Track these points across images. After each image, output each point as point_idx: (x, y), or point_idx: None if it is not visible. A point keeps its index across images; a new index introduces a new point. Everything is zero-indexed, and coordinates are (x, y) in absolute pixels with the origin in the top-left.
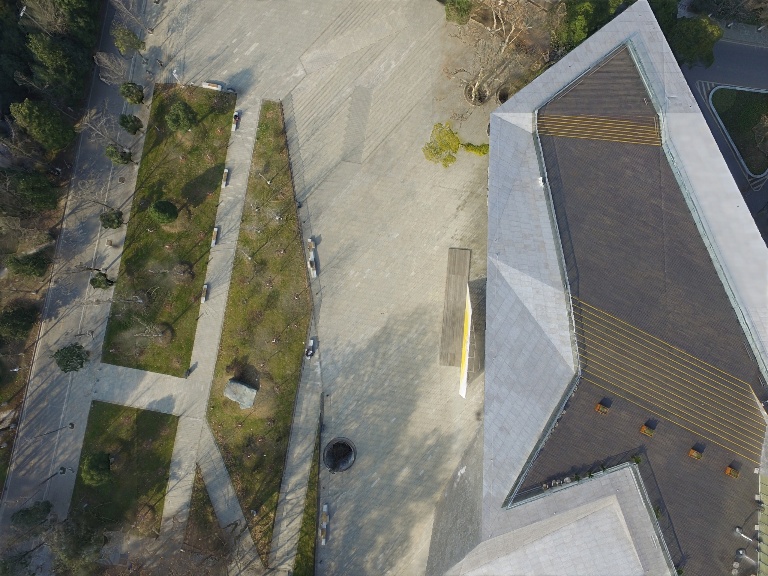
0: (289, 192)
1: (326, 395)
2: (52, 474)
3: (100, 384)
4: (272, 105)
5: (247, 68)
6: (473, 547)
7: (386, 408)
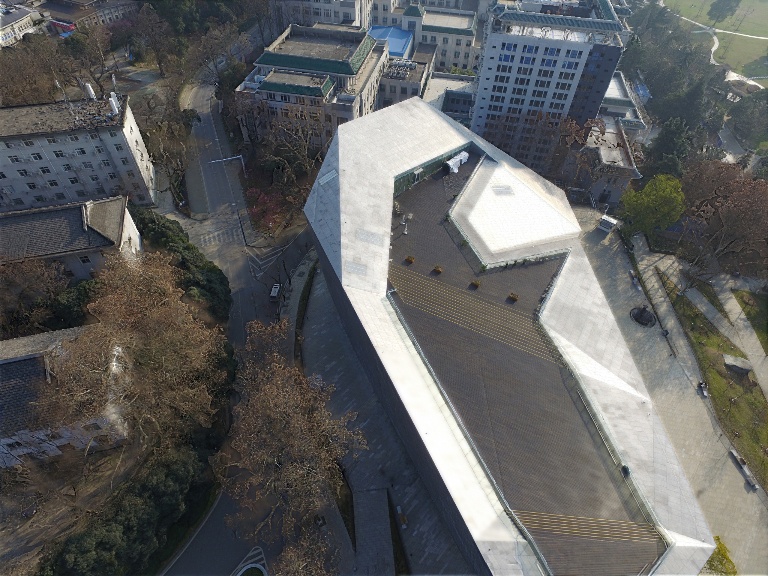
0: None
1: (673, 355)
2: None
3: None
4: None
5: None
6: None
7: None
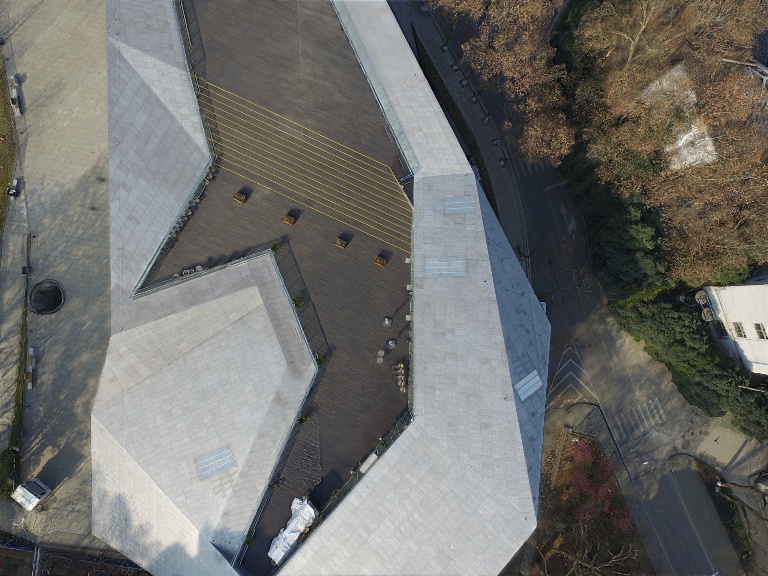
0: None
1: (32, 236)
2: None
3: None
4: None
5: None
6: None
7: (97, 249)
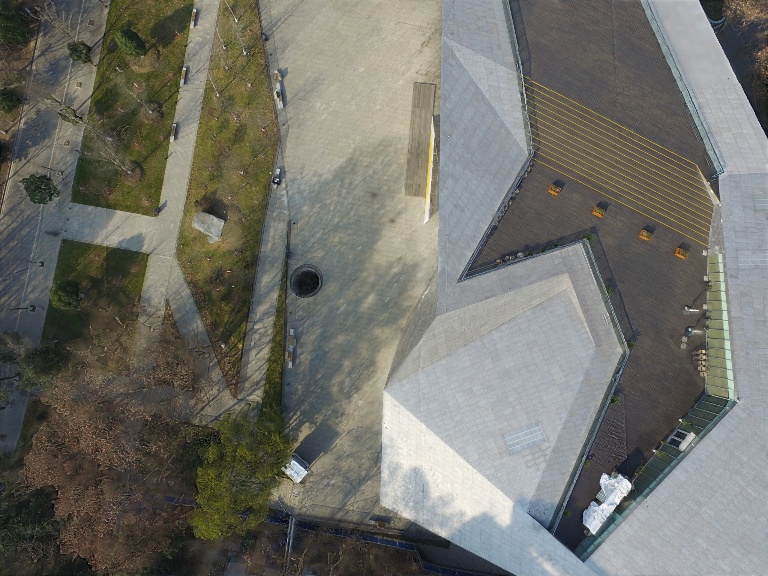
0: (256, 28)
1: (293, 223)
2: (22, 312)
3: (70, 223)
4: None
5: None
6: (430, 325)
7: (352, 237)
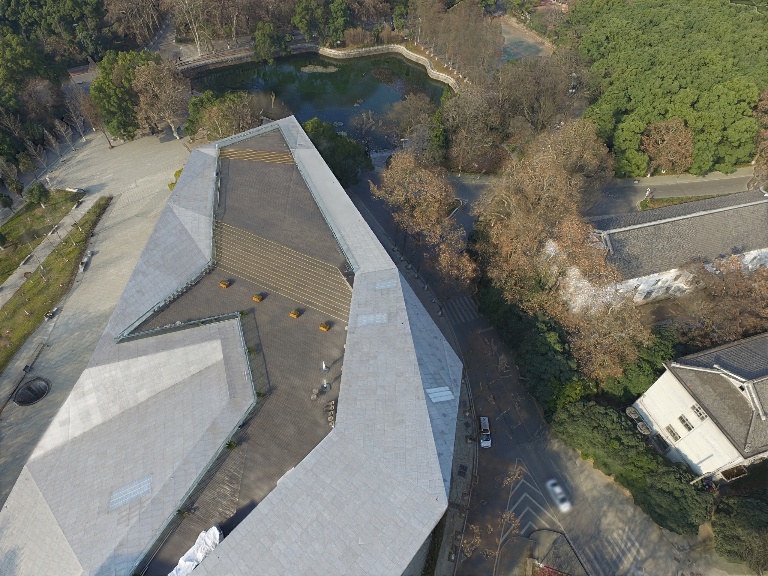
0: None
1: (47, 345)
2: None
3: None
4: (106, 198)
5: (100, 184)
6: None
7: None
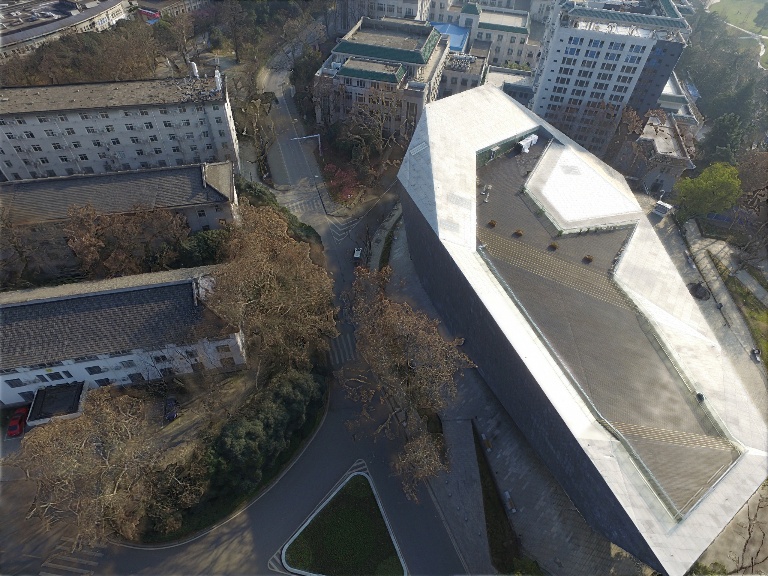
0: None
1: (727, 325)
2: None
3: None
4: None
5: None
6: None
7: None
